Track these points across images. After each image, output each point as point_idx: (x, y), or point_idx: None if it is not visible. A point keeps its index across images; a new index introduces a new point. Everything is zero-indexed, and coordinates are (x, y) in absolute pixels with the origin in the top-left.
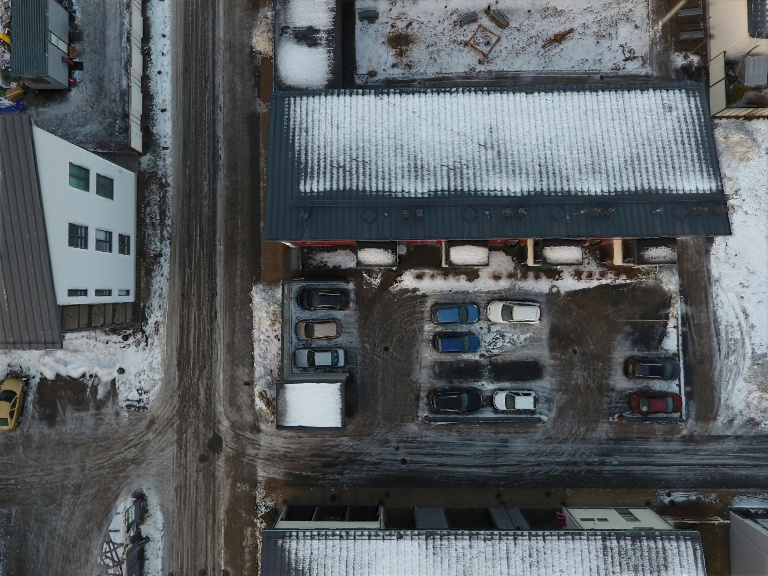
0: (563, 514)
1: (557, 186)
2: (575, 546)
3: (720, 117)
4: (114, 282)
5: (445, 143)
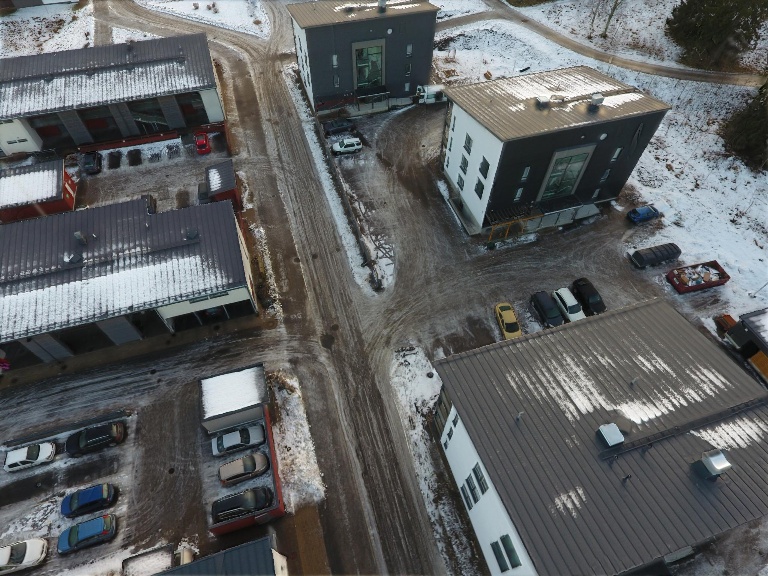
0: (1, 368)
1: None
2: None
3: None
4: (452, 450)
5: None
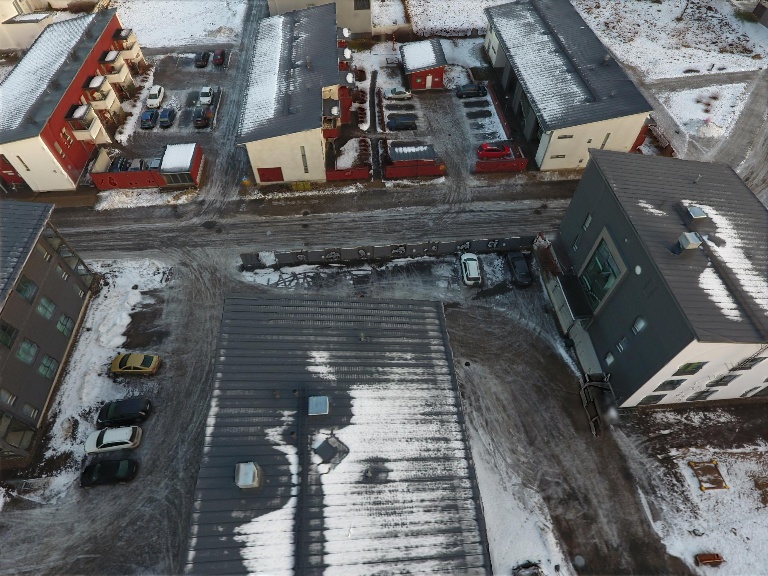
0: None
1: (69, 49)
2: (259, 46)
3: None
4: None
5: (24, 85)
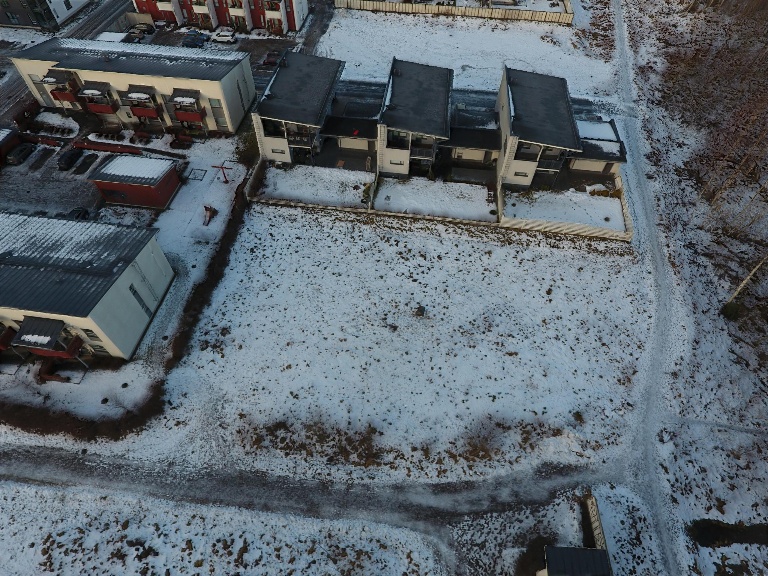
0: None
1: None
2: None
3: (338, 8)
4: None
5: None
